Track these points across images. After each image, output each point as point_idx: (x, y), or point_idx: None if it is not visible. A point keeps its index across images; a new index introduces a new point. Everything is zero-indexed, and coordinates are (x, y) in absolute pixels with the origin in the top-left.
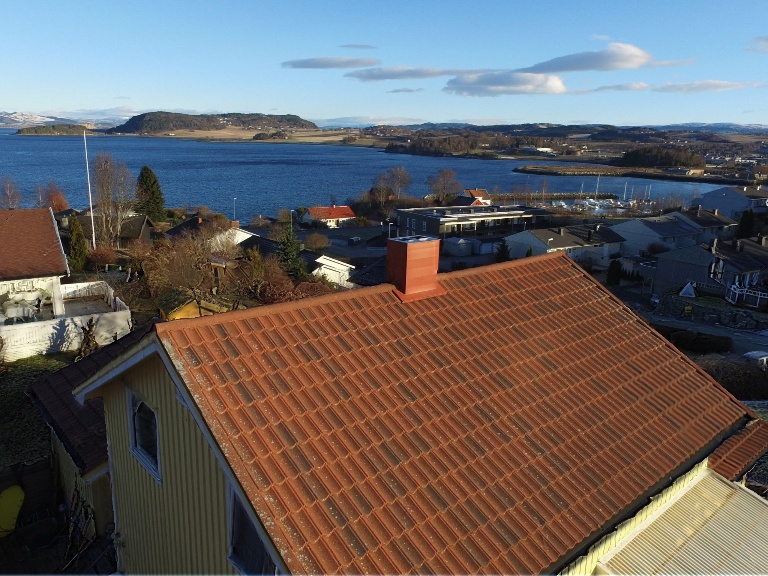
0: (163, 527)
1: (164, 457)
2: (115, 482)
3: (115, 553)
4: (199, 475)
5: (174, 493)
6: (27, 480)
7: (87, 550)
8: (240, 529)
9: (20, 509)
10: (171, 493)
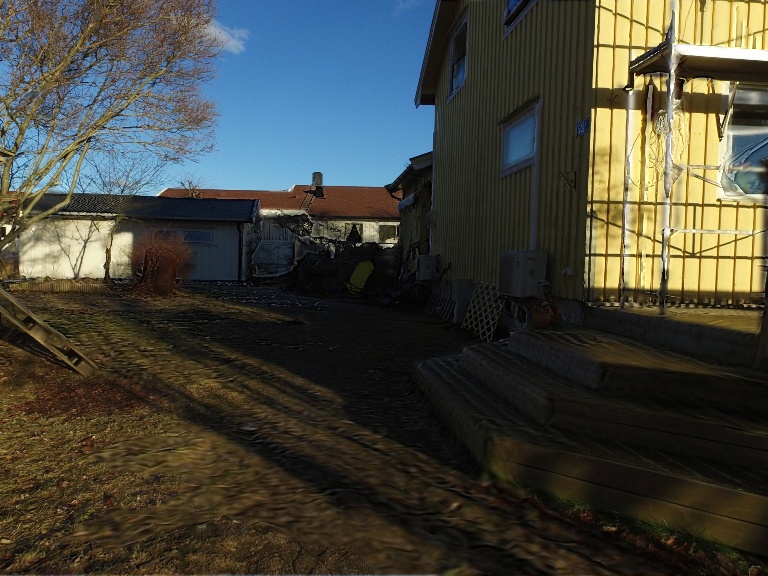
0: None
1: (469, 46)
2: (435, 168)
3: (429, 249)
4: (490, 1)
5: None
6: (378, 260)
7: (410, 277)
8: None
9: (369, 276)
10: None
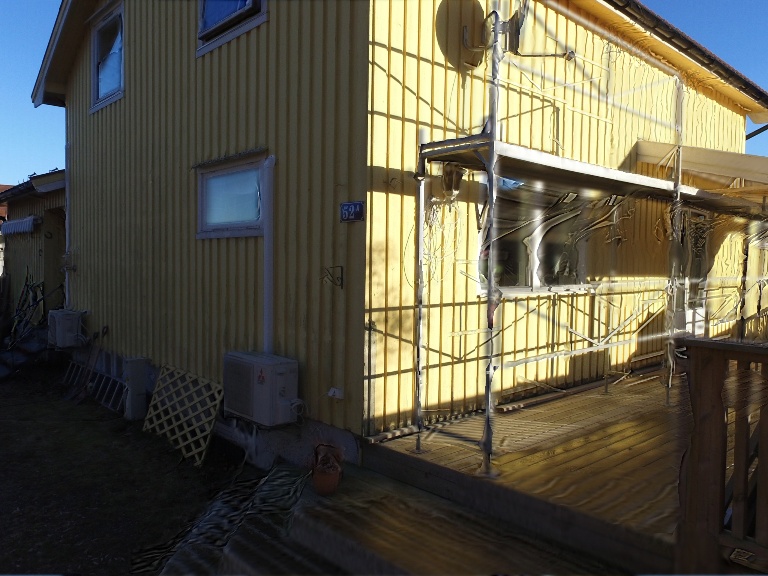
0: (122, 154)
1: (129, 48)
2: (71, 192)
3: (64, 298)
4: None
5: (137, 81)
6: None
7: (31, 332)
8: (213, 0)
9: None
10: (134, 87)
